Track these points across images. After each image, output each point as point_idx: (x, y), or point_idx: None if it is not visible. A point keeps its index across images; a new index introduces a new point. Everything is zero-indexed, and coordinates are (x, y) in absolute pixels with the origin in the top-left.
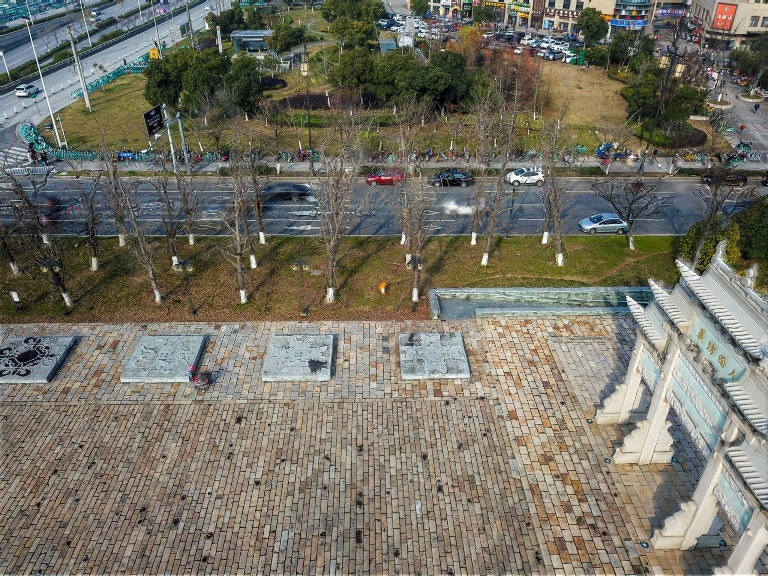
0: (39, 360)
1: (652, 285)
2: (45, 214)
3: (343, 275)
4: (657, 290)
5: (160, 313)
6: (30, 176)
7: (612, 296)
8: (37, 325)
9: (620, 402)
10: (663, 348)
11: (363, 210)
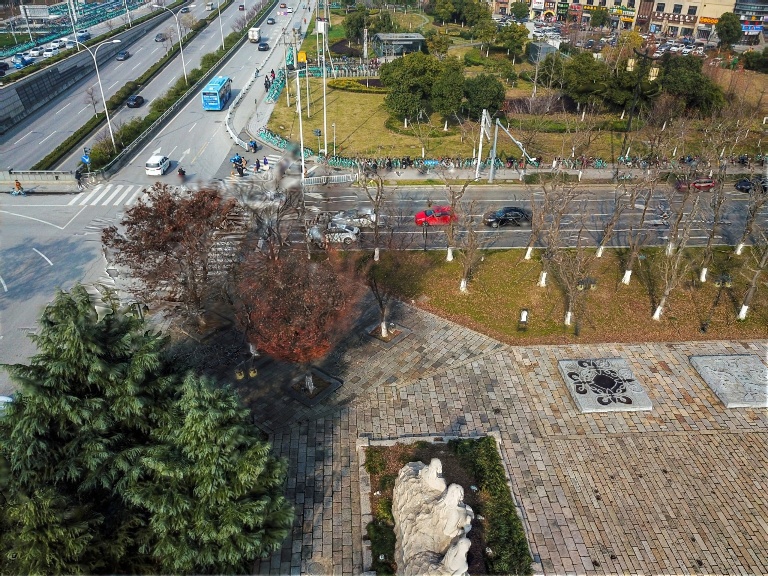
0: (623, 386)
1: None
2: (395, 226)
3: None
4: None
5: (670, 331)
6: (329, 185)
7: None
8: (558, 347)
9: None
10: None
11: (709, 218)
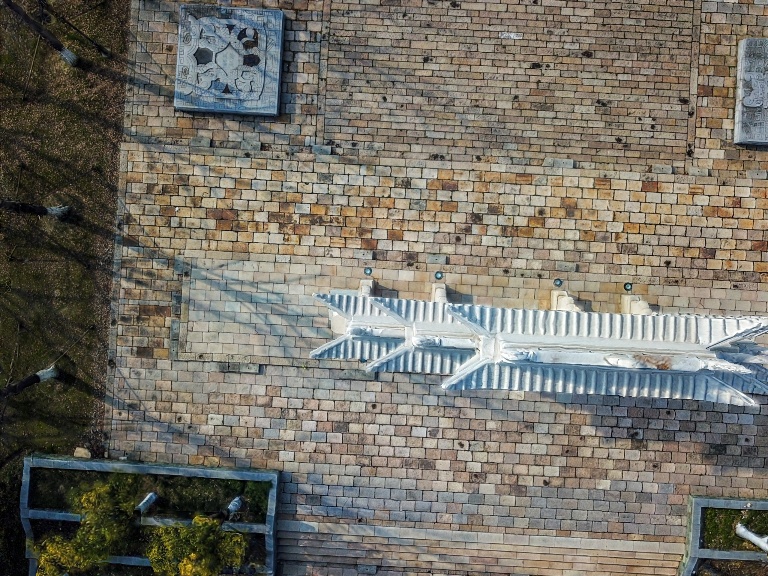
0: None
1: None
2: None
3: None
4: None
5: None
6: None
7: None
8: None
9: None
10: None
11: None
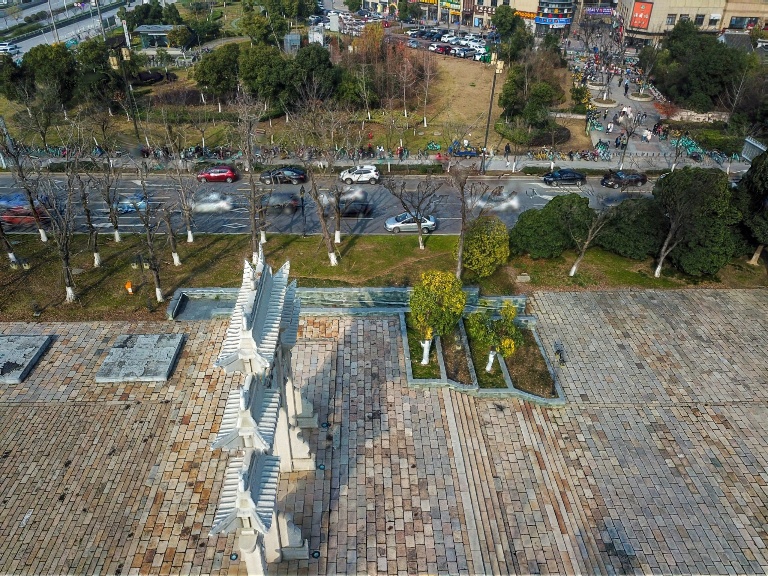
0: None
1: None
2: None
3: (103, 274)
4: None
5: None
6: None
7: (366, 297)
8: None
9: None
10: None
11: (177, 207)
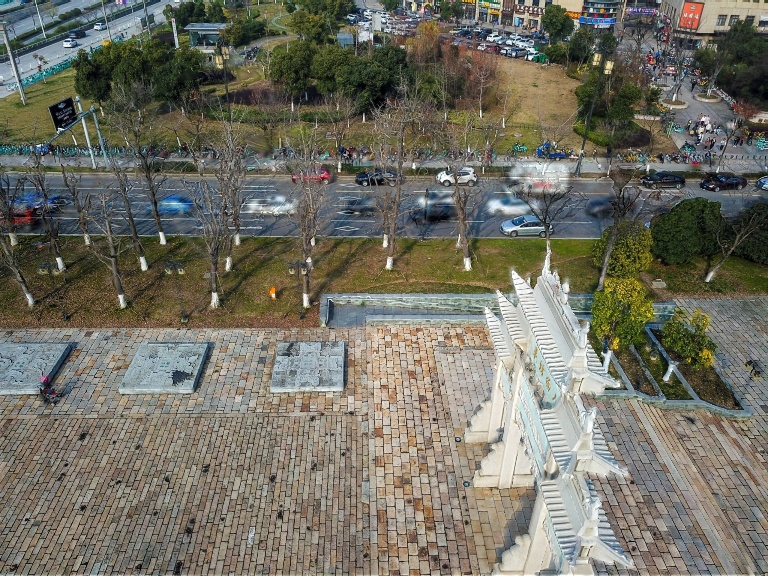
0: None
1: (500, 297)
2: None
3: (237, 279)
4: (504, 303)
5: (31, 318)
6: None
7: None
8: None
9: (487, 420)
10: (512, 365)
11: (281, 209)
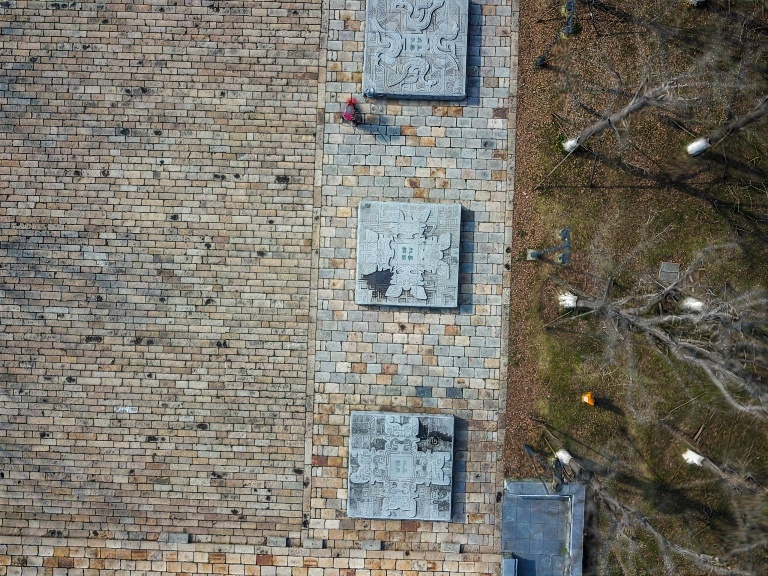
0: None
1: None
2: None
3: None
4: None
5: (544, 7)
6: None
7: None
8: None
9: None
10: None
11: None
